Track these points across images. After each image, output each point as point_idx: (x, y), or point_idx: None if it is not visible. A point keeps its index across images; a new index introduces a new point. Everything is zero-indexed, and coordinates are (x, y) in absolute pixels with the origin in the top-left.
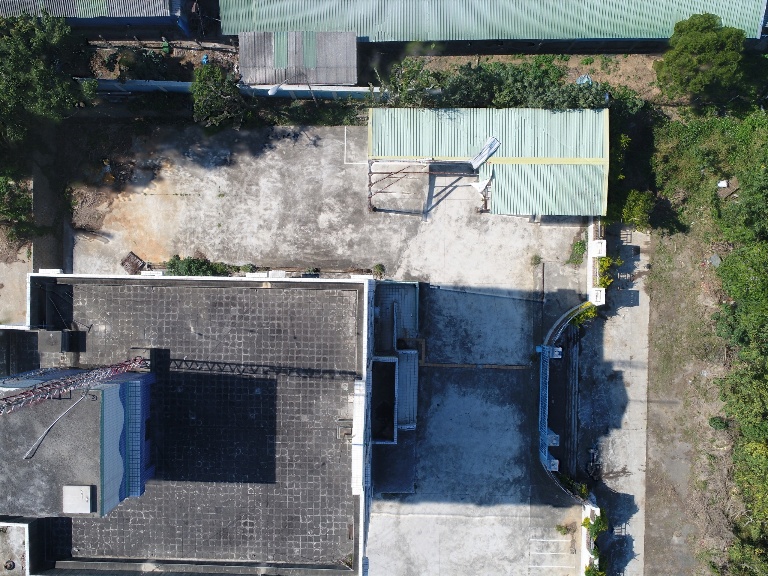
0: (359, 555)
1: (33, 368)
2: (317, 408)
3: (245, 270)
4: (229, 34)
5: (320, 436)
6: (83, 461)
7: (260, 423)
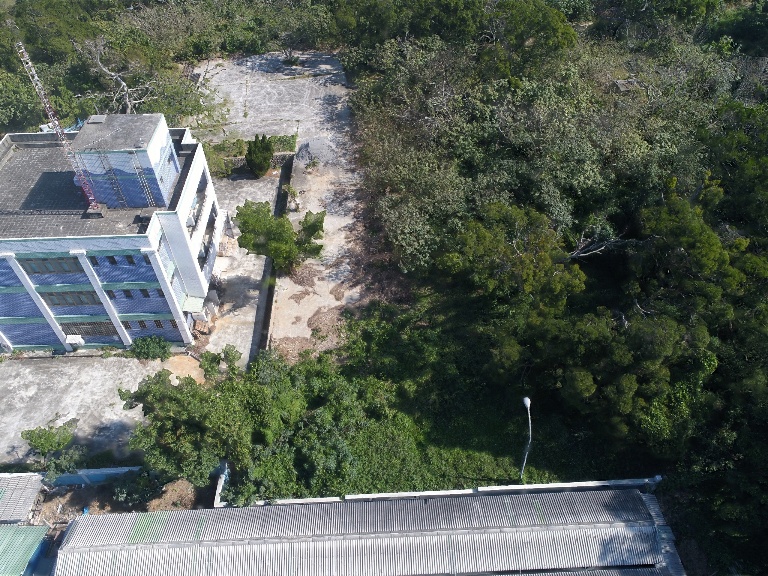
0: (1, 144)
1: (173, 207)
2: (0, 200)
3: (108, 353)
4: (43, 526)
5: (6, 190)
6: (89, 130)
7: (39, 193)
